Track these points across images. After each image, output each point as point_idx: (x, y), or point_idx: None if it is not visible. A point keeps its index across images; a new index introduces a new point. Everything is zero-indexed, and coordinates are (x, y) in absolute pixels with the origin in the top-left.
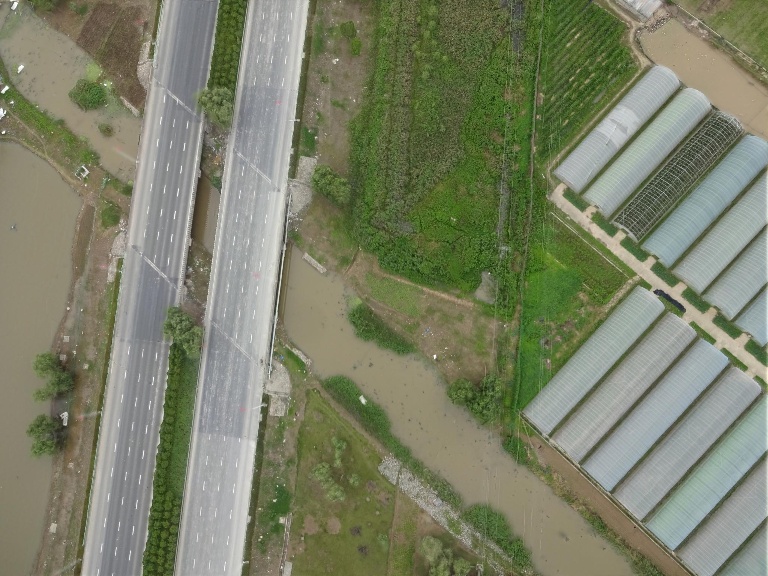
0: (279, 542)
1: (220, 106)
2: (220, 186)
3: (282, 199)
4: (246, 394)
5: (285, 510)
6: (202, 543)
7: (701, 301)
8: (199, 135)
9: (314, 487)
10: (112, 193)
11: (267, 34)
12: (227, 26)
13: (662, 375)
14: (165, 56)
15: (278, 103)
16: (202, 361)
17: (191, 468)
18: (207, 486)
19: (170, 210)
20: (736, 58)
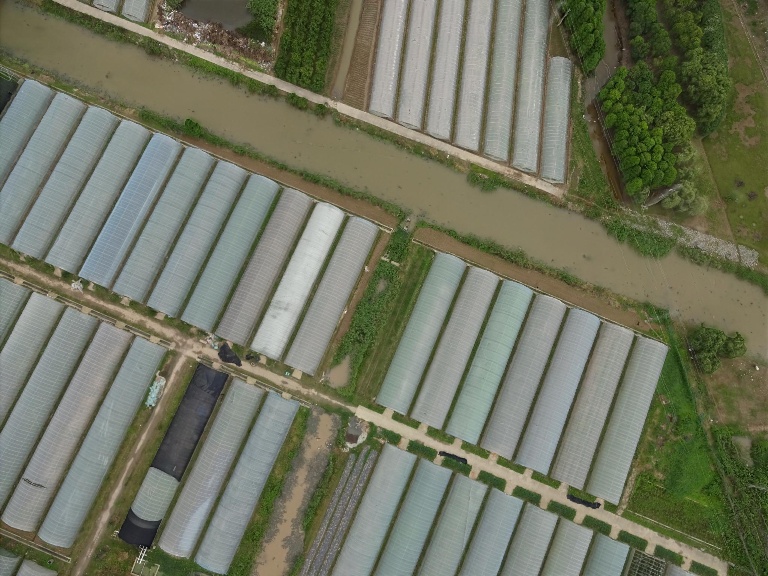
0: None
1: None
2: None
3: None
4: None
5: None
6: None
7: (557, 512)
8: None
9: None
10: None
11: None
12: None
13: (565, 428)
14: None
15: None
16: None
17: None
18: None
19: None
20: None
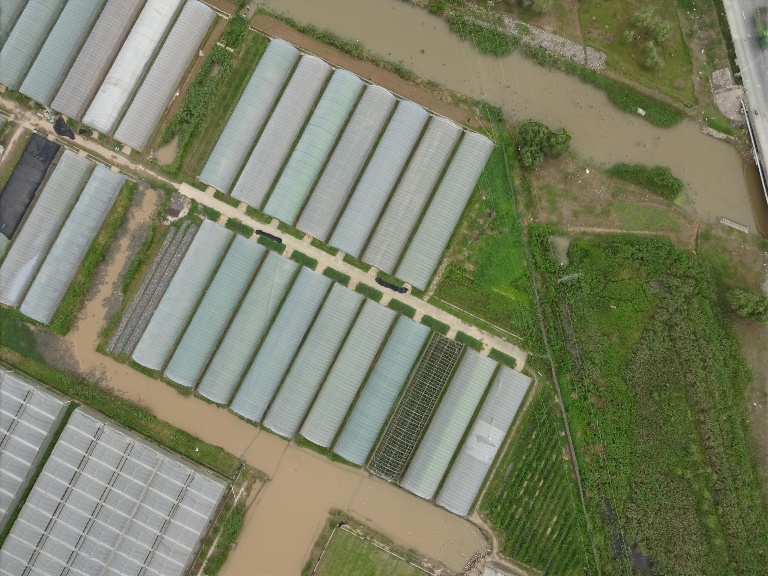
0: None
1: None
2: None
3: None
4: (759, 79)
5: None
6: None
7: (365, 293)
8: None
9: None
10: None
11: None
12: None
13: (382, 216)
14: None
15: None
16: None
17: None
18: None
19: None
20: (390, 544)
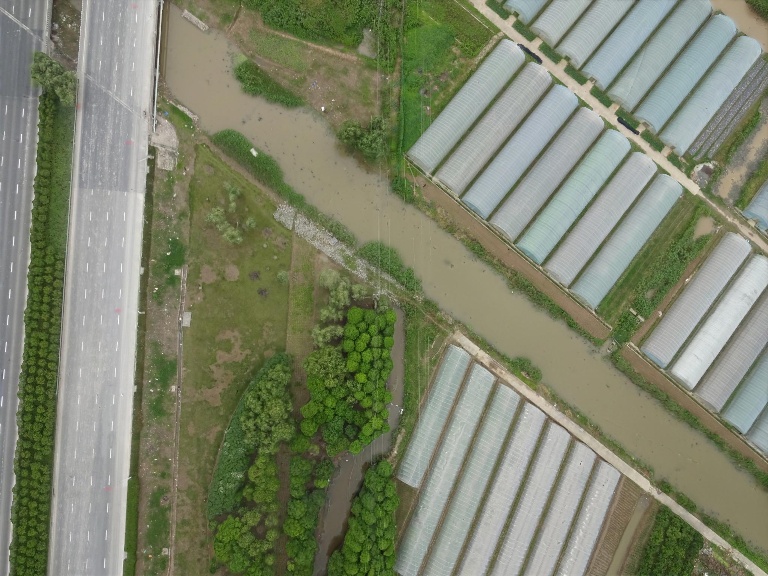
0: (176, 294)
1: None
2: None
3: None
4: (130, 147)
5: (180, 262)
6: (91, 299)
7: (554, 53)
8: None
9: (209, 238)
10: None
11: None
12: None
13: (525, 117)
14: None
15: None
16: (77, 115)
17: (73, 225)
18: (93, 242)
19: None
20: None
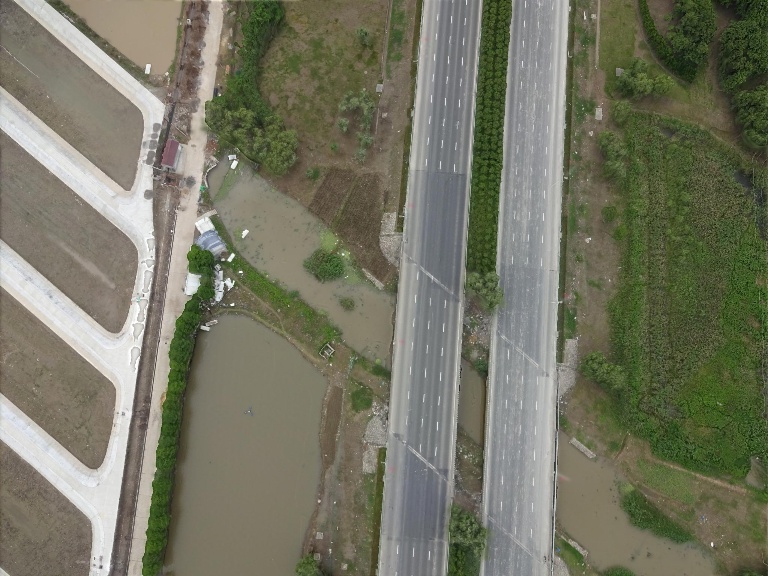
0: None
1: (495, 293)
2: (485, 370)
3: (551, 384)
4: None
5: None
6: None
7: None
8: (459, 316)
9: None
10: (361, 373)
11: (521, 212)
12: (482, 203)
13: None
14: (415, 230)
15: (538, 284)
16: (481, 560)
17: None
18: None
19: (433, 395)
20: None
